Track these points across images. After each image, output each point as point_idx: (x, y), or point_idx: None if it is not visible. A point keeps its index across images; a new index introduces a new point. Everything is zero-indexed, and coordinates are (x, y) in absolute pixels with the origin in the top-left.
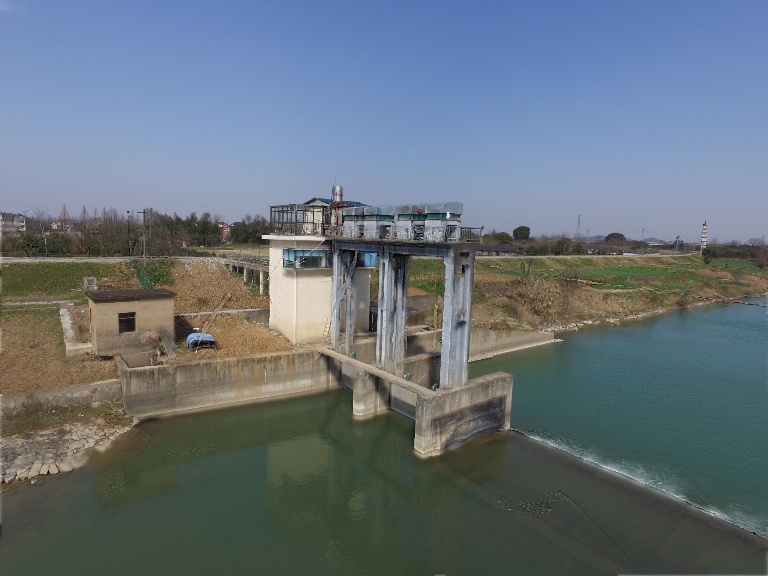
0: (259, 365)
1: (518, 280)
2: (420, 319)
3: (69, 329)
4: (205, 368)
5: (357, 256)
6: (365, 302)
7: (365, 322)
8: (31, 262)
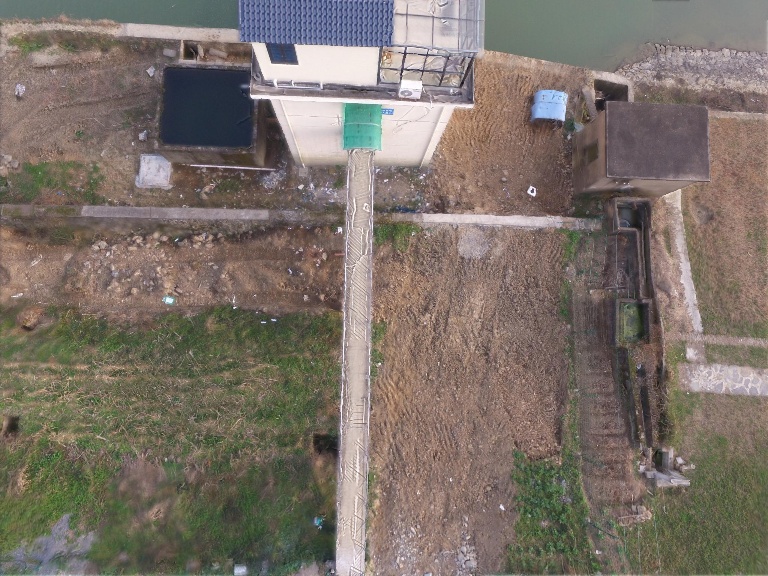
0: None
1: None
2: None
3: (682, 253)
4: None
5: None
6: None
7: None
8: None
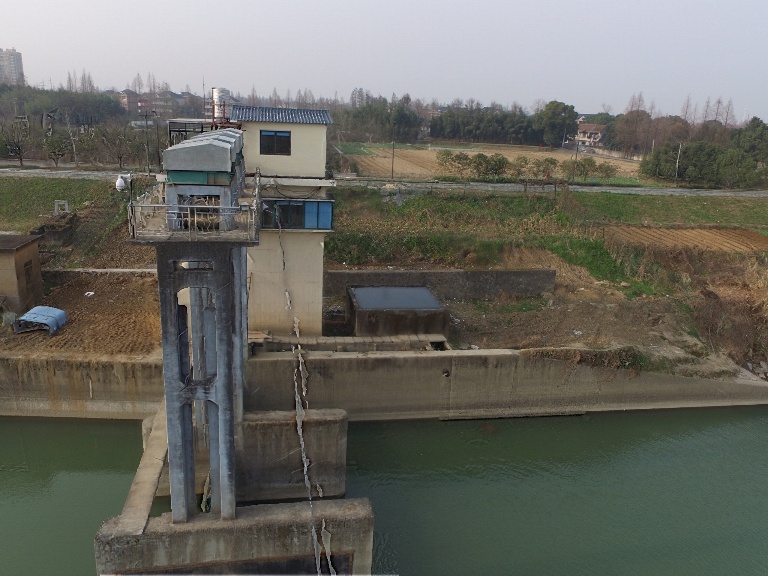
0: (80, 372)
1: (760, 257)
2: (438, 323)
3: None
4: (1, 365)
5: (288, 210)
6: (313, 287)
7: (313, 319)
8: (25, 177)
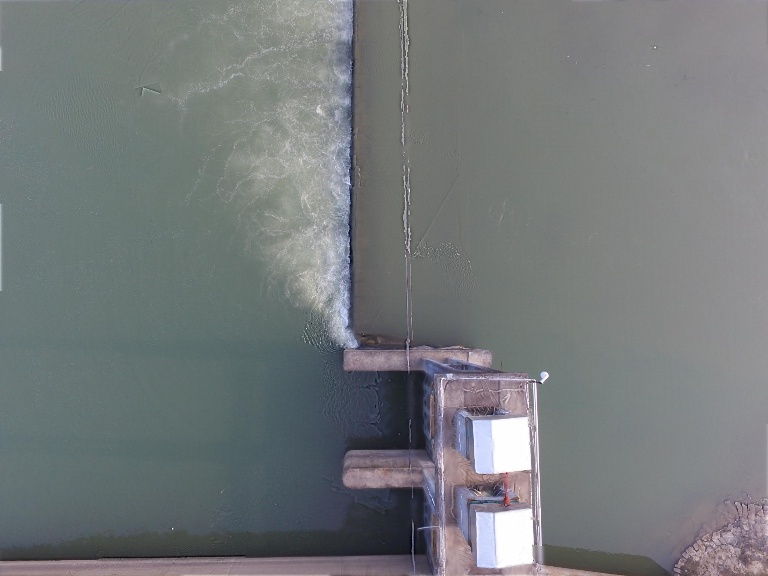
0: None
1: None
2: None
3: None
4: None
5: None
6: None
7: None
8: None
